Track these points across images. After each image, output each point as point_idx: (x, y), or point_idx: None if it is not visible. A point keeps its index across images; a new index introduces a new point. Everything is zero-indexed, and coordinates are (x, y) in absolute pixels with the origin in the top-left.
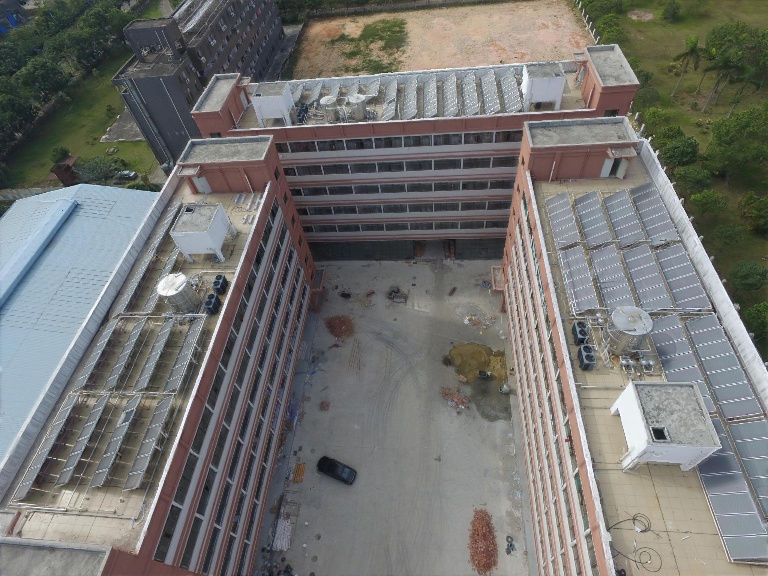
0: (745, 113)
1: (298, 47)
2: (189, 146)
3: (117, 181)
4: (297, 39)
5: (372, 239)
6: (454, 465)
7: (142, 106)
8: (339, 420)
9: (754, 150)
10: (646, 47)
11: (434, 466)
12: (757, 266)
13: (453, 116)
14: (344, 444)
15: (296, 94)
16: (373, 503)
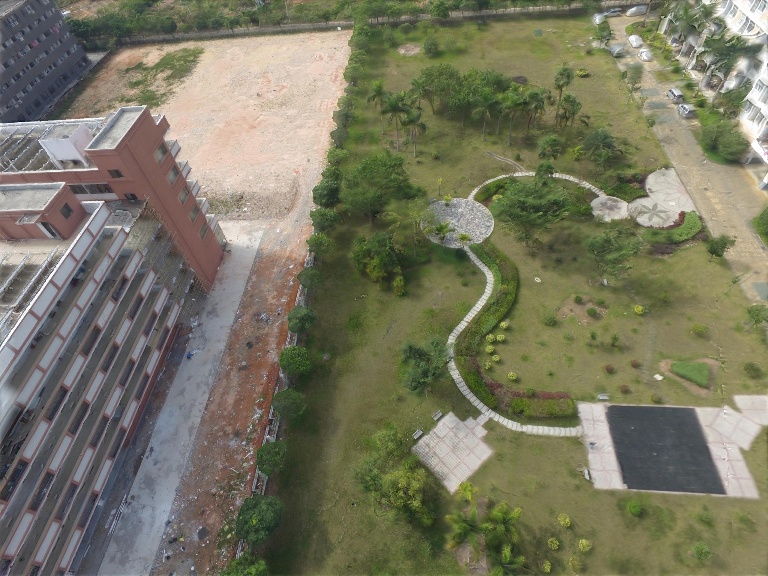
0: (368, 159)
1: (92, 75)
2: None
3: None
4: (94, 67)
5: None
6: None
7: None
8: None
9: (364, 195)
10: (393, 82)
11: None
12: (302, 310)
13: None
14: None
15: None
16: None
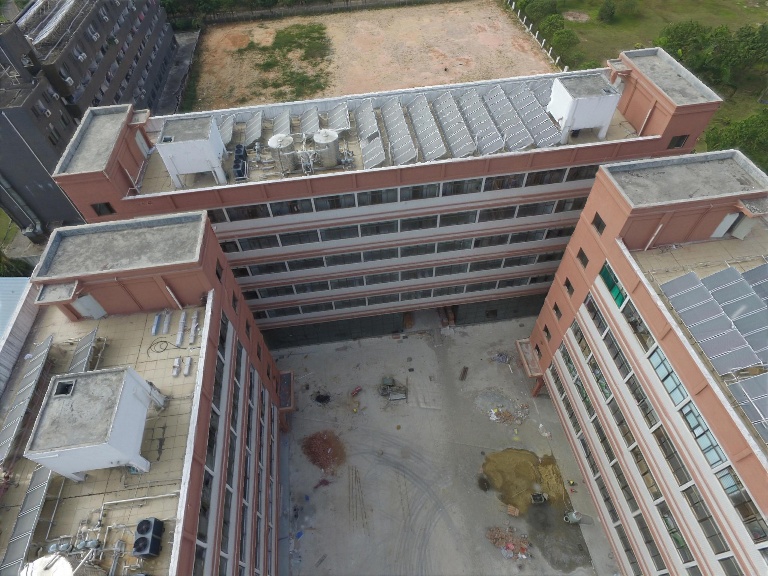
0: (748, 121)
1: (198, 59)
2: (53, 241)
3: None
4: (195, 49)
5: (349, 317)
6: None
7: None
8: None
9: (767, 163)
10: (593, 49)
11: None
12: None
13: (470, 155)
14: None
15: (224, 131)
16: None
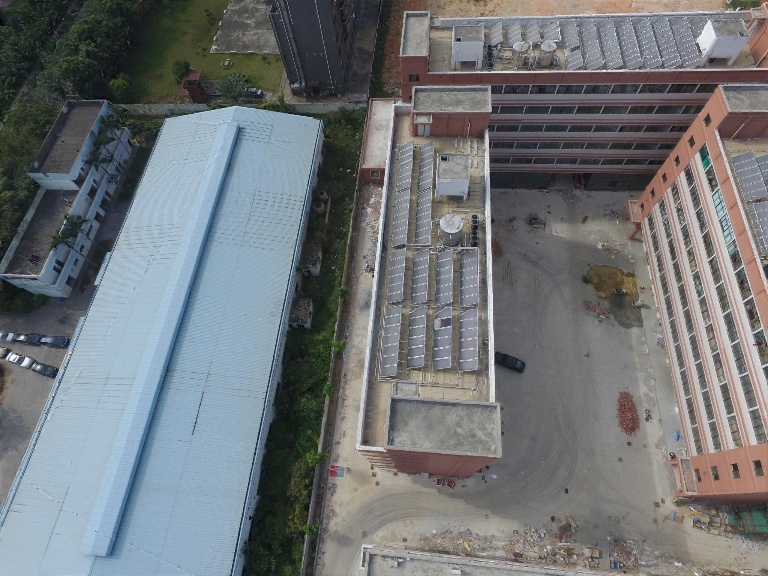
0: None
1: None
2: (414, 93)
3: (244, 98)
4: None
5: (517, 170)
6: (600, 360)
7: (289, 27)
8: (503, 325)
9: None
10: None
11: (585, 360)
12: None
13: (637, 68)
14: (510, 343)
15: None
16: (540, 386)
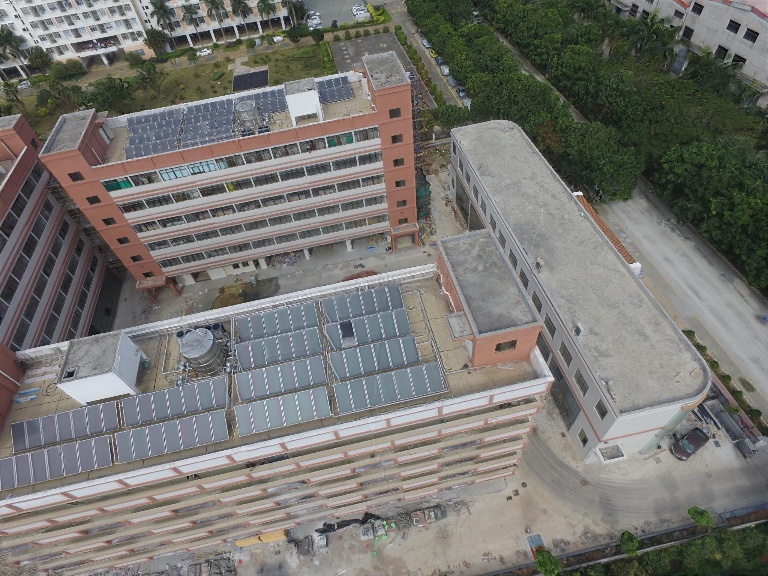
0: None
1: None
2: None
3: None
4: None
5: None
6: None
7: None
8: None
9: None
10: None
11: None
12: None
13: None
14: None
15: None
16: None
